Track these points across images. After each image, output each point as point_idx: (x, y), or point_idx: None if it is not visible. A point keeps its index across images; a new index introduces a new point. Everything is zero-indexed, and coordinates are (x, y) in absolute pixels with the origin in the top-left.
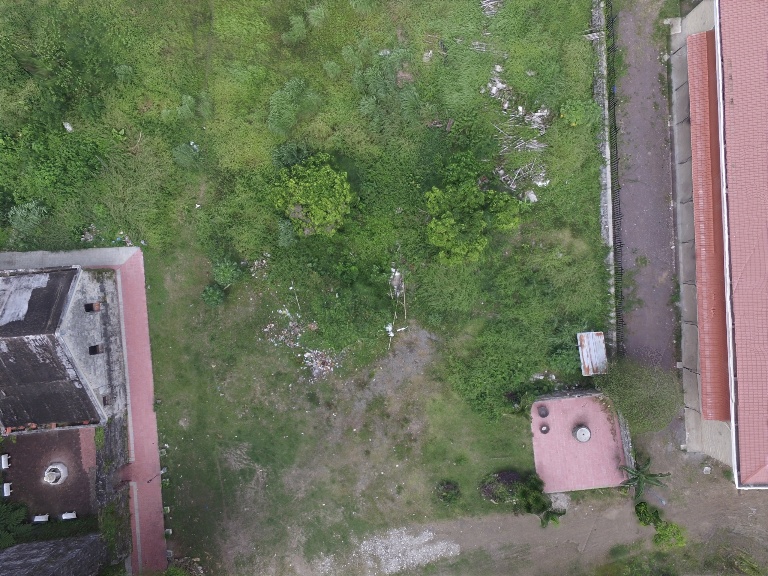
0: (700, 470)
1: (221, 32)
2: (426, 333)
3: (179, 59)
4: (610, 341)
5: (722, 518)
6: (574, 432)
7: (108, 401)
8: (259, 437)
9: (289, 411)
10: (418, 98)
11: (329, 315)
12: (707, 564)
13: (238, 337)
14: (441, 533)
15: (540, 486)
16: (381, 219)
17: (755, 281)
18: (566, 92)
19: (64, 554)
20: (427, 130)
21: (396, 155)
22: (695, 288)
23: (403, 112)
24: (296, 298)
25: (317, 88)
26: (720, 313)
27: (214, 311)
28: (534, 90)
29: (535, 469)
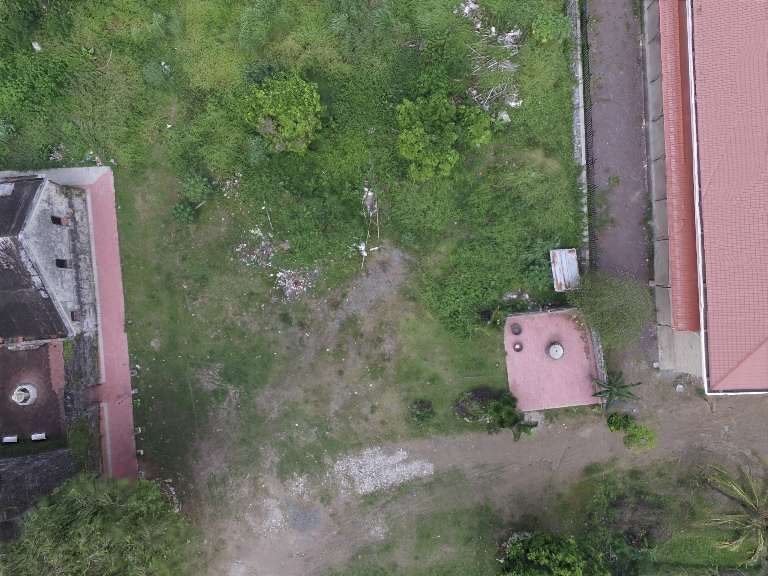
0: (673, 388)
1: None
2: (399, 253)
3: None
4: (583, 260)
5: (695, 435)
6: (547, 349)
7: (77, 317)
8: (231, 357)
9: (262, 331)
10: (390, 16)
11: (299, 225)
12: (680, 481)
13: (210, 257)
14: (415, 452)
15: (513, 402)
16: (354, 138)
17: (723, 187)
18: (538, 10)
19: (30, 463)
20: (400, 49)
21: (369, 74)
22: (666, 201)
23: (375, 29)
24: (268, 217)
25: (289, 8)
26: (690, 222)
27: (185, 231)
28: (507, 9)
29: (509, 387)
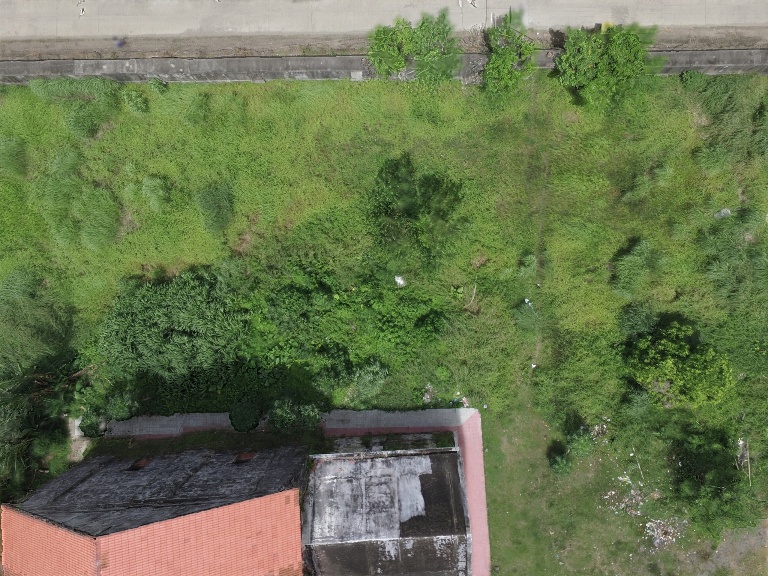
0: None
1: (559, 188)
2: None
3: (514, 214)
4: None
5: None
6: None
7: None
8: None
9: None
10: None
11: (715, 505)
12: None
13: (578, 504)
14: None
15: None
16: None
17: None
18: None
19: None
20: None
21: (743, 321)
22: None
23: (757, 280)
24: (638, 466)
25: (656, 247)
26: None
27: (553, 476)
28: None
29: None
